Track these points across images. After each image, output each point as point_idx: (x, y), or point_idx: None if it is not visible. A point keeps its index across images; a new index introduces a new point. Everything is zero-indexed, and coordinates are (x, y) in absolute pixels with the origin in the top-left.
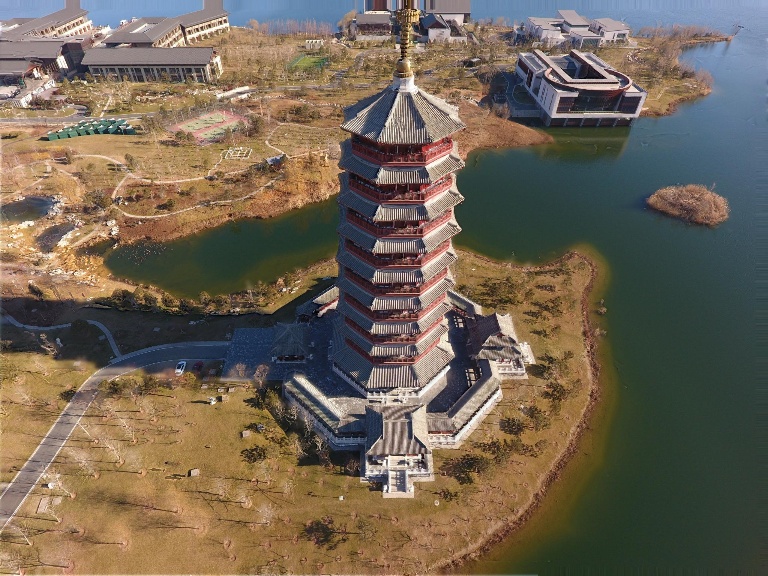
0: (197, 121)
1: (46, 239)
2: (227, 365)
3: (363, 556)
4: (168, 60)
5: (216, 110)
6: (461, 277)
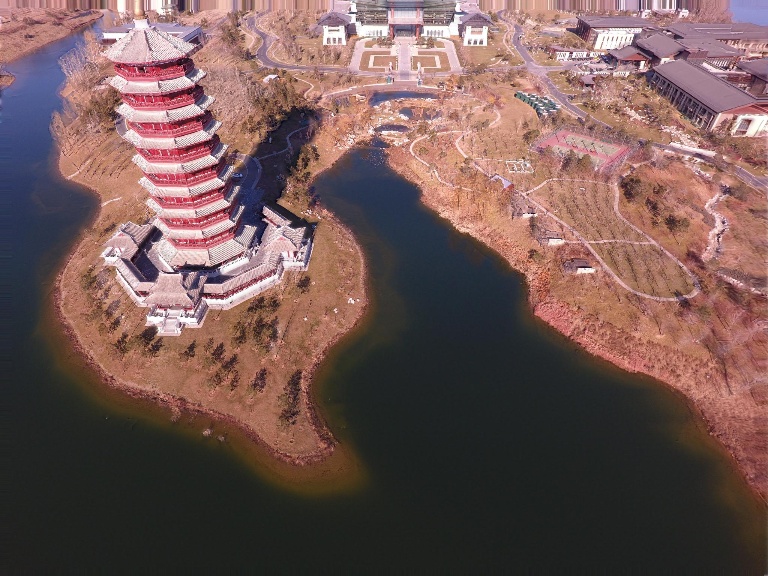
0: (588, 141)
1: (390, 127)
2: None
3: (89, 243)
4: (700, 93)
5: (625, 146)
6: (293, 305)
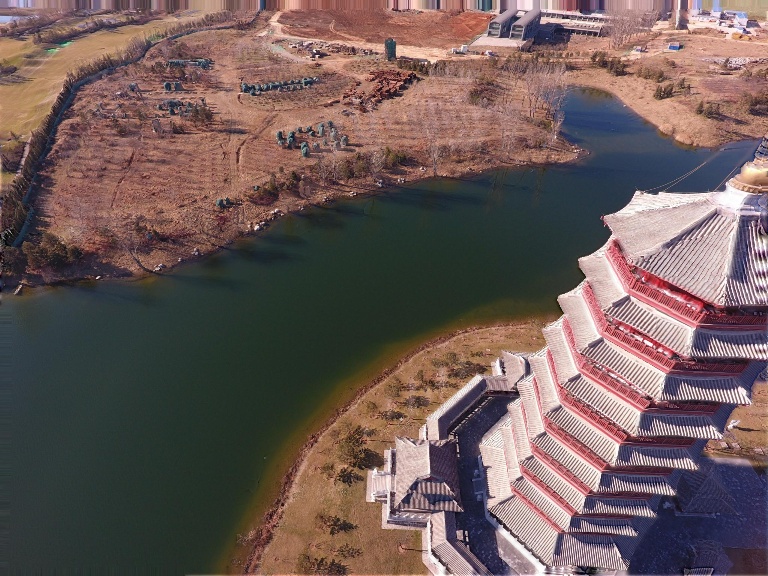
0: None
1: None
2: (758, 481)
3: None
4: None
5: None
6: None
